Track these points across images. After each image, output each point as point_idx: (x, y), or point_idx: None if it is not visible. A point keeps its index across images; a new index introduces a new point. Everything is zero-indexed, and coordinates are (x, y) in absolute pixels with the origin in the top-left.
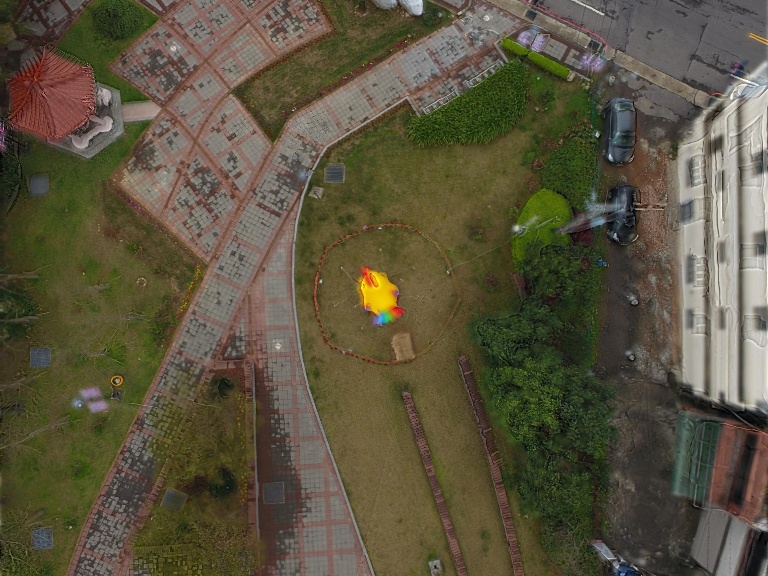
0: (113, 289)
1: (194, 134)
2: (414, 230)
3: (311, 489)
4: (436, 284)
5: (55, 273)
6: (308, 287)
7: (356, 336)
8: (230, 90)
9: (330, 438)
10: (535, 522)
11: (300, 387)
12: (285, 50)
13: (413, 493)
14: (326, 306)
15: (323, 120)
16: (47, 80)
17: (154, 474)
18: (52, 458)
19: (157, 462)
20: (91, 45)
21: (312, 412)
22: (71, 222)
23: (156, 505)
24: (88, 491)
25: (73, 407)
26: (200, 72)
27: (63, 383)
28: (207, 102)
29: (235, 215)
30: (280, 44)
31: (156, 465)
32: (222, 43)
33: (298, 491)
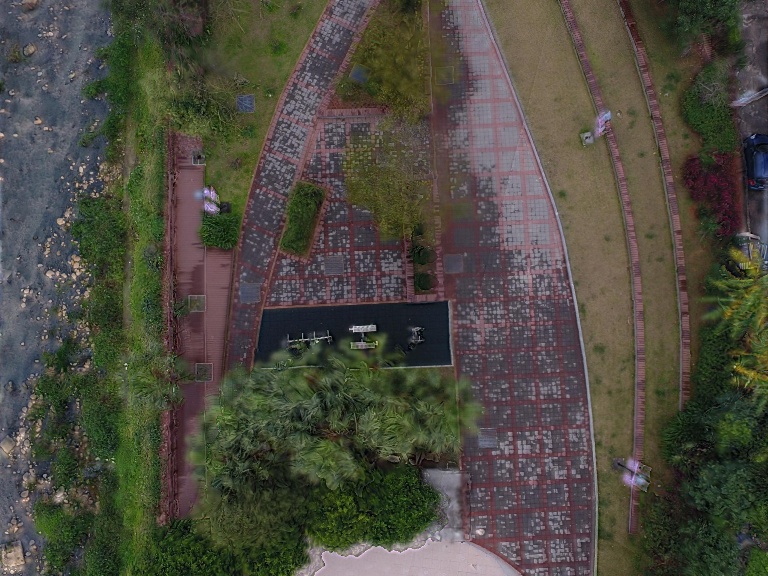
0: None
1: None
2: None
3: (477, 73)
4: None
5: None
6: None
7: None
8: None
9: (494, 30)
10: (674, 99)
11: None
12: None
13: (566, 77)
14: None
15: None
16: None
17: (341, 55)
18: (254, 38)
19: (344, 45)
20: None
21: (477, 9)
22: None
23: (345, 76)
24: (285, 67)
25: None
26: None
27: None
28: None
29: None
30: None
31: (343, 48)
32: None
33: (466, 74)
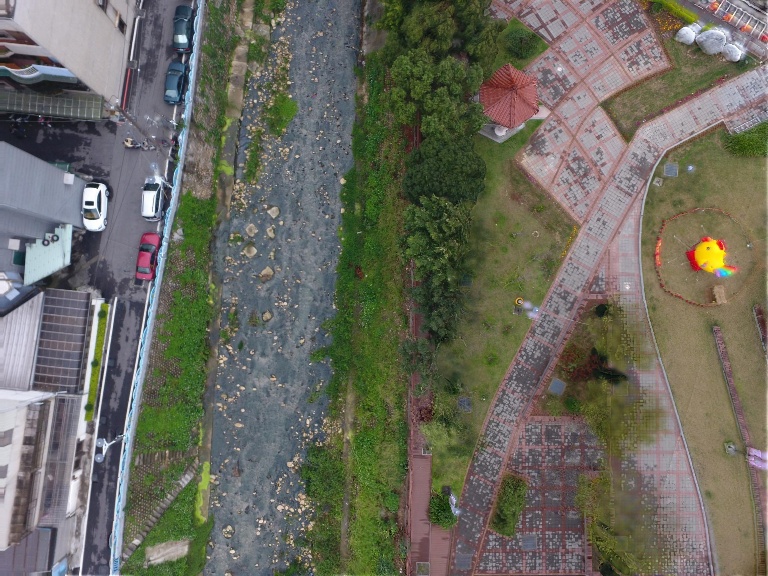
0: (517, 237)
1: (573, 132)
2: (727, 214)
3: (646, 387)
4: (740, 253)
5: (476, 222)
6: (651, 247)
7: (682, 284)
8: (599, 103)
9: (662, 353)
10: None
11: (641, 317)
12: (638, 77)
13: (716, 395)
14: (662, 262)
15: (663, 130)
16: (519, 88)
17: (541, 368)
18: (473, 351)
19: (543, 360)
20: (502, 61)
21: (649, 334)
22: (488, 187)
23: (545, 388)
24: (496, 375)
25: (488, 317)
26: (578, 88)
27: (481, 299)
28: (583, 110)
29: (601, 192)
30: (635, 73)
31: (543, 362)
32: (594, 68)
33: (638, 388)
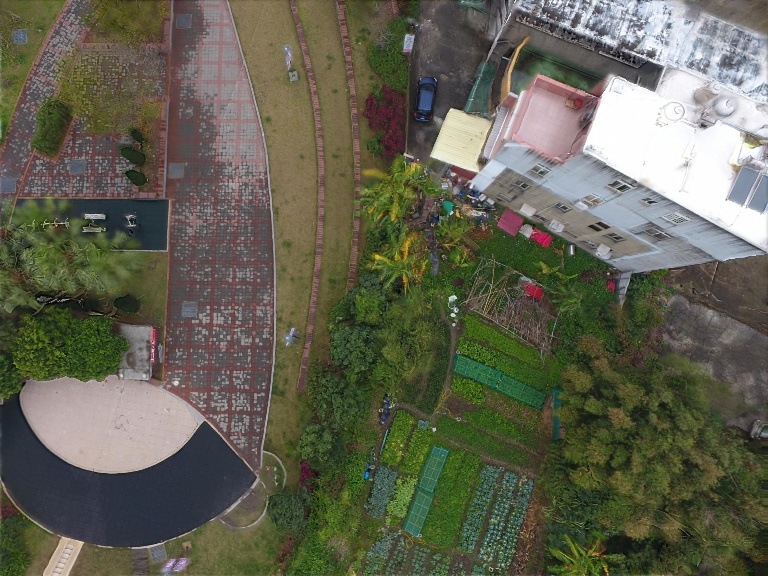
0: None
1: None
2: None
3: (210, 20)
4: None
5: None
6: None
7: None
8: None
9: None
10: (365, 47)
11: None
12: None
13: (282, 26)
14: None
15: None
16: None
17: (101, 1)
18: None
19: None
20: None
21: None
22: None
23: (100, 17)
24: (54, 8)
25: None
26: None
27: None
28: None
29: None
30: None
31: None
32: None
33: (201, 21)
